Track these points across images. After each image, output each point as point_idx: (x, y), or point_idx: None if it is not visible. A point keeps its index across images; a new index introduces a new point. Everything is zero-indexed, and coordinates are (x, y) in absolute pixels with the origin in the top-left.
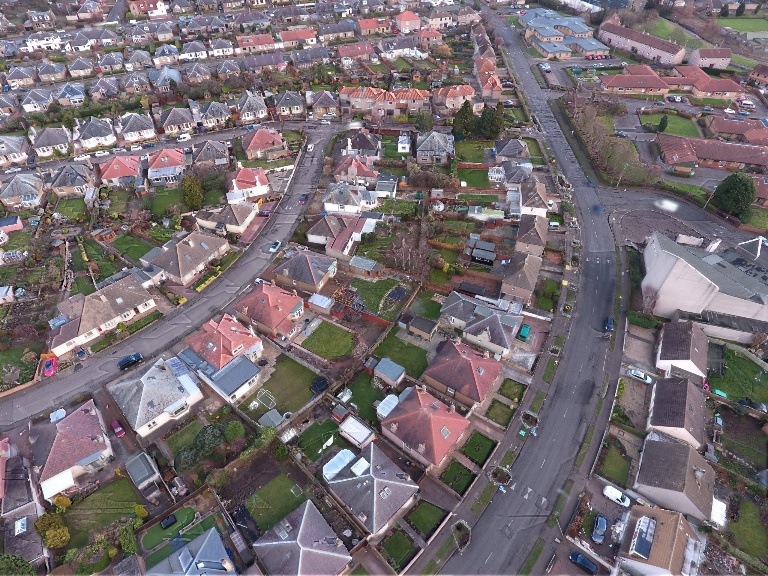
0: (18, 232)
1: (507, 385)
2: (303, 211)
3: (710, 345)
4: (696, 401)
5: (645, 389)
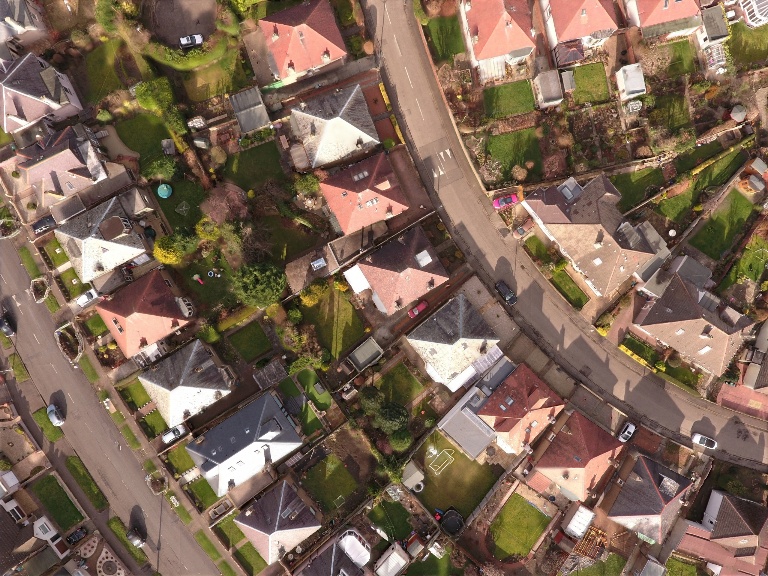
0: None
1: None
2: None
3: None
4: None
5: None
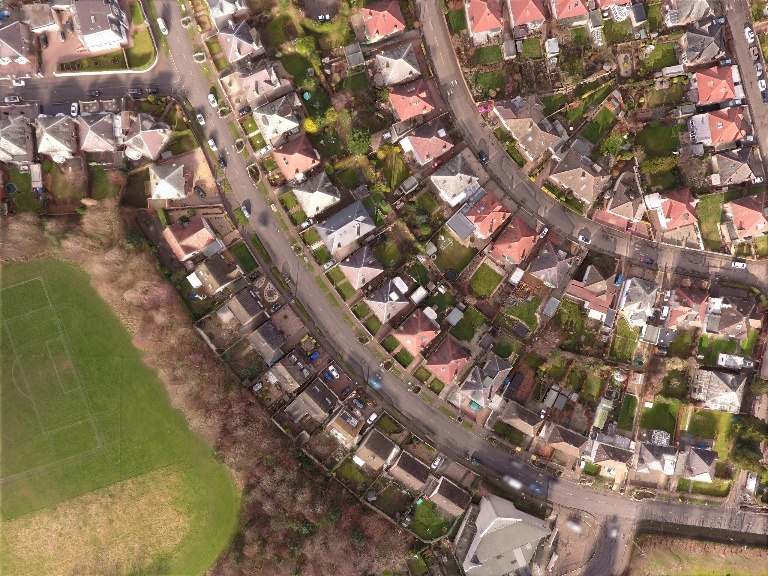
0: (630, 25)
1: (440, 384)
2: (631, 260)
3: (454, 517)
4: (413, 482)
5: (429, 462)
